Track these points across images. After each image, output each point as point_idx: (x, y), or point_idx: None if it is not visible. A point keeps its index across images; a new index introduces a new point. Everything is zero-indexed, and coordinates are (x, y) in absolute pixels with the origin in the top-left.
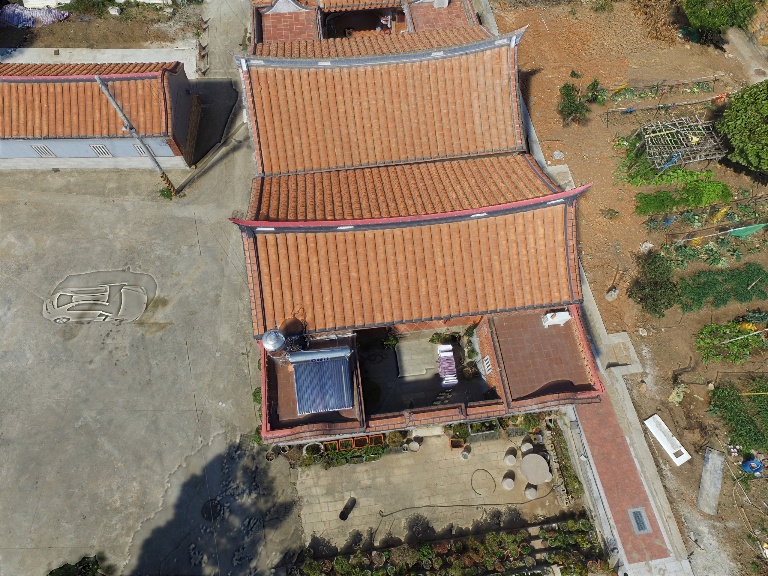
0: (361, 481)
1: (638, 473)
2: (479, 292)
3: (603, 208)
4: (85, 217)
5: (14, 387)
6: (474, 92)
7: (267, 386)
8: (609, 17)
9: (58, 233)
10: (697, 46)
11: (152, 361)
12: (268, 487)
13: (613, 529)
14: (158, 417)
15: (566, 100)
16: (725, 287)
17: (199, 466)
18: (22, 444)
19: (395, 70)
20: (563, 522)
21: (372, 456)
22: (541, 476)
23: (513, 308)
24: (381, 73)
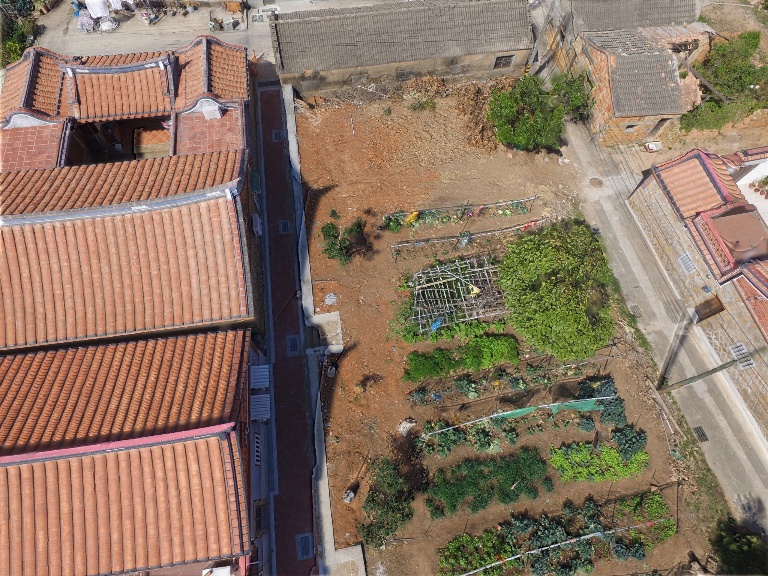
0: None
1: None
2: (113, 545)
3: (367, 372)
4: None
5: None
6: (190, 250)
7: None
8: (429, 118)
9: None
10: (522, 154)
11: None
12: None
13: None
14: None
15: (330, 241)
16: (490, 481)
17: None
18: None
19: (91, 226)
20: None
21: None
22: None
23: (156, 566)
24: (74, 229)
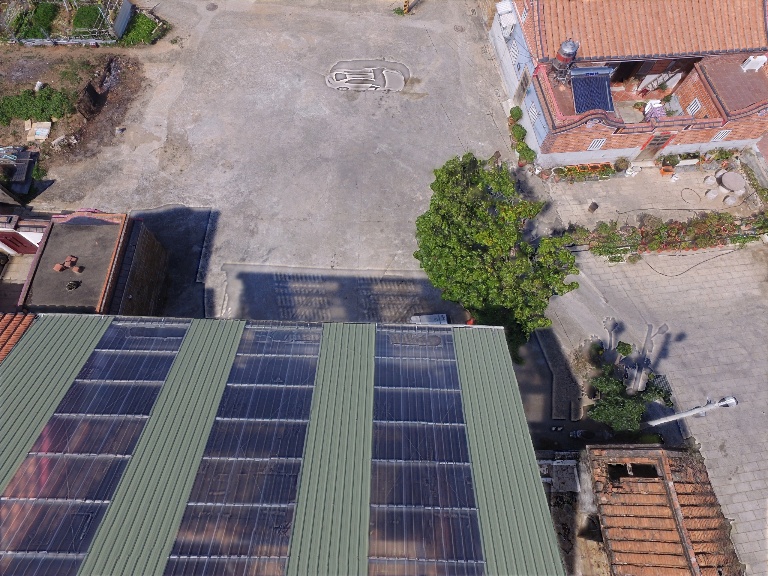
0: (598, 193)
1: None
2: (700, 38)
3: None
4: (340, 25)
5: (320, 128)
6: None
7: None
8: None
9: (322, 34)
10: None
11: (420, 116)
12: (531, 192)
13: None
14: (435, 149)
15: None
16: None
17: None
18: (338, 161)
19: None
20: (759, 215)
21: (604, 177)
22: (740, 185)
23: (725, 50)
24: None
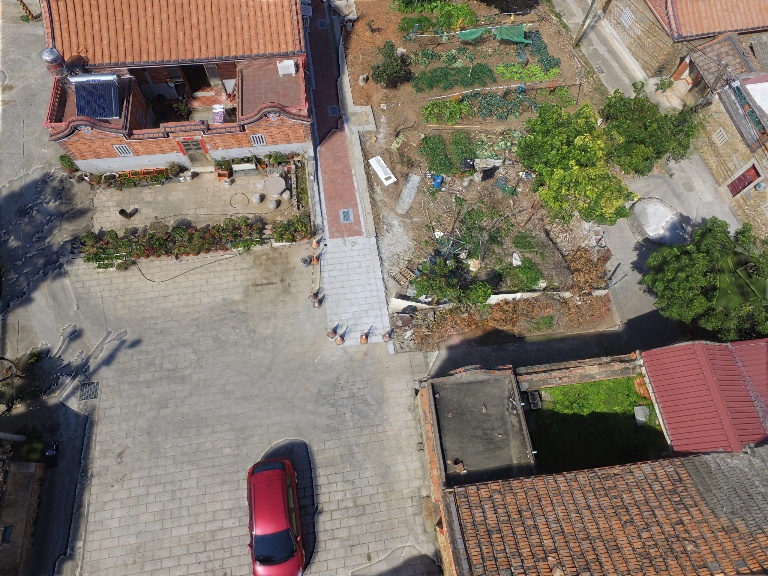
0: (145, 199)
1: (354, 190)
2: (224, 43)
3: (373, 27)
4: None
5: None
6: None
7: (56, 103)
8: None
9: None
10: None
11: None
12: (70, 199)
13: (324, 220)
14: None
15: None
16: (455, 78)
17: (19, 186)
18: None
19: None
20: None
21: (155, 182)
22: (278, 189)
23: (249, 55)
24: None
